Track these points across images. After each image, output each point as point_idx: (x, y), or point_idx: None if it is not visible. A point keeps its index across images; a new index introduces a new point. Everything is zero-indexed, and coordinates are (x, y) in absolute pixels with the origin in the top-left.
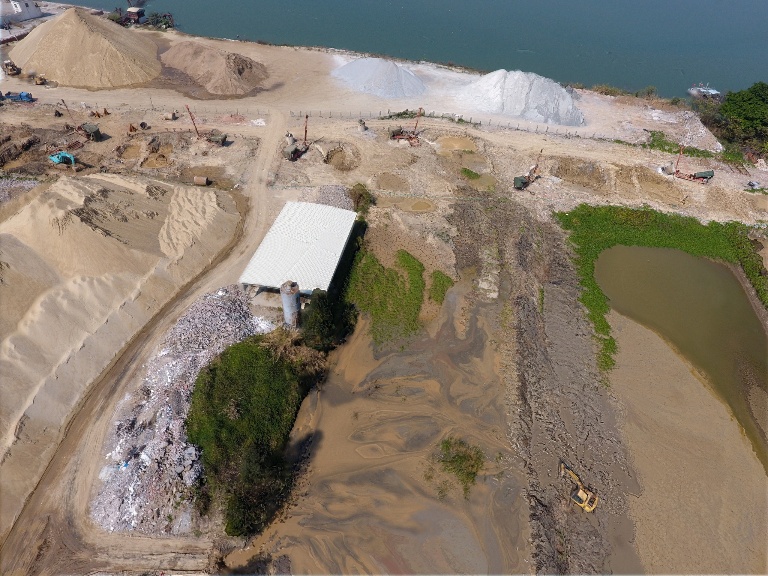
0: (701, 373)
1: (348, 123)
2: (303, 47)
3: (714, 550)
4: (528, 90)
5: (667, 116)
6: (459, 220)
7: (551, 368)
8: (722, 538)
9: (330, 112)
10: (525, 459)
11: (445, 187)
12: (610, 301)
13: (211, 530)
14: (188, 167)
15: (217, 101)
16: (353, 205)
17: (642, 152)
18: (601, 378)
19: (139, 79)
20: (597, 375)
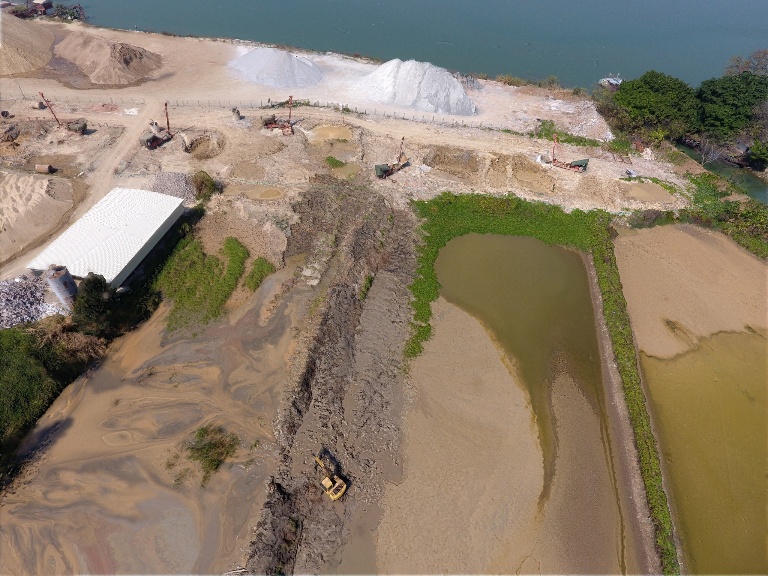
0: (511, 360)
1: (225, 112)
2: (208, 38)
3: (458, 539)
4: (421, 80)
5: (566, 106)
6: (306, 208)
7: (351, 355)
8: (472, 526)
9: (208, 101)
10: (284, 446)
11: (302, 175)
12: (442, 288)
13: None
14: (37, 155)
15: (96, 91)
16: (195, 193)
17: (527, 141)
18: (402, 365)
19: (21, 69)
20: (400, 362)
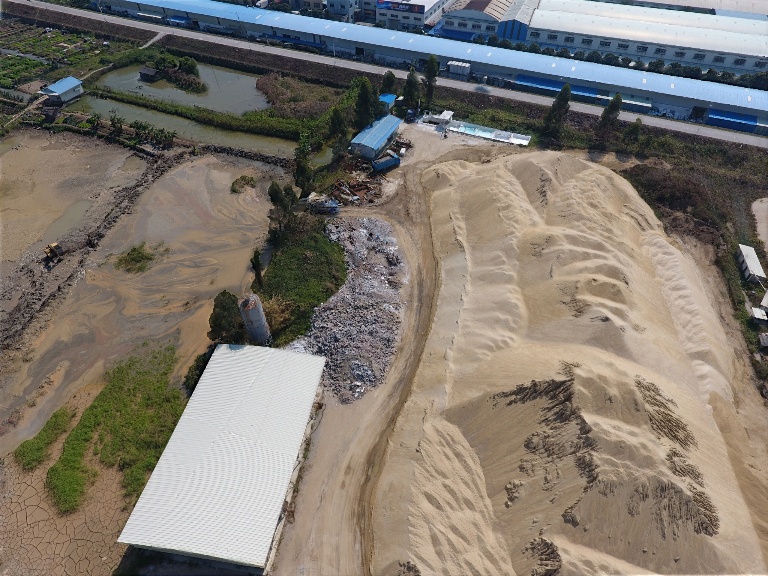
0: None
1: None
2: None
3: None
4: None
5: None
6: None
7: None
8: None
9: None
10: None
11: None
12: None
13: None
14: None
15: None
16: None
17: None
18: None
19: None
20: None
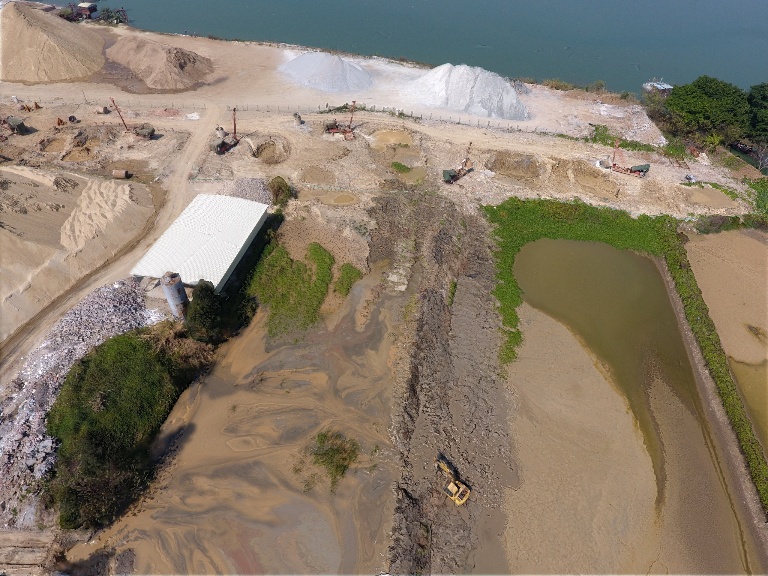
0: (604, 366)
1: (285, 117)
2: (254, 42)
3: (584, 543)
4: (473, 84)
5: (615, 110)
6: (381, 213)
7: (449, 361)
8: (595, 531)
9: (267, 106)
10: (403, 452)
11: (372, 180)
12: (524, 294)
13: (56, 523)
14: (111, 160)
15: (155, 95)
16: (272, 198)
17: (583, 146)
18: (500, 371)
19: (78, 73)
20: (496, 368)
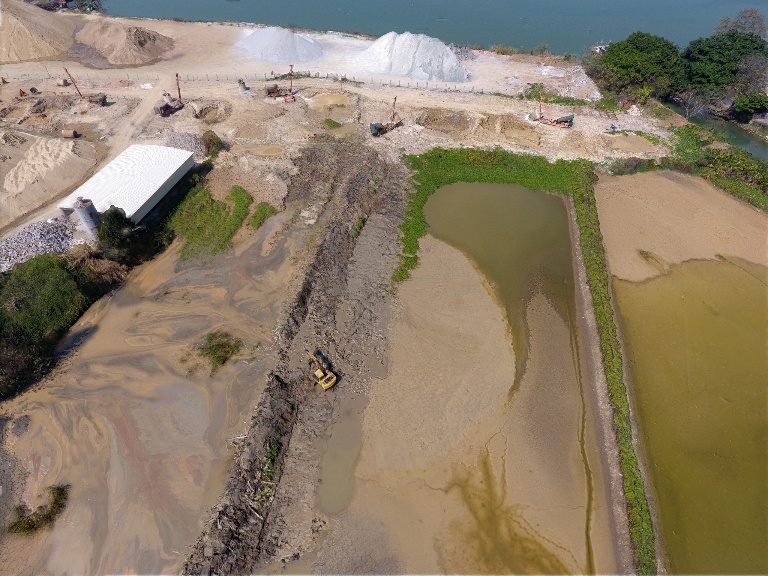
0: (491, 284)
1: (232, 85)
2: (216, 22)
3: (435, 420)
4: (416, 50)
5: (557, 71)
6: (306, 162)
7: (343, 280)
8: (447, 411)
9: (216, 75)
10: (283, 348)
11: (302, 135)
12: (429, 227)
13: None
14: (63, 124)
15: (114, 70)
16: (204, 150)
17: (517, 103)
18: (390, 288)
19: (46, 53)
20: (388, 286)
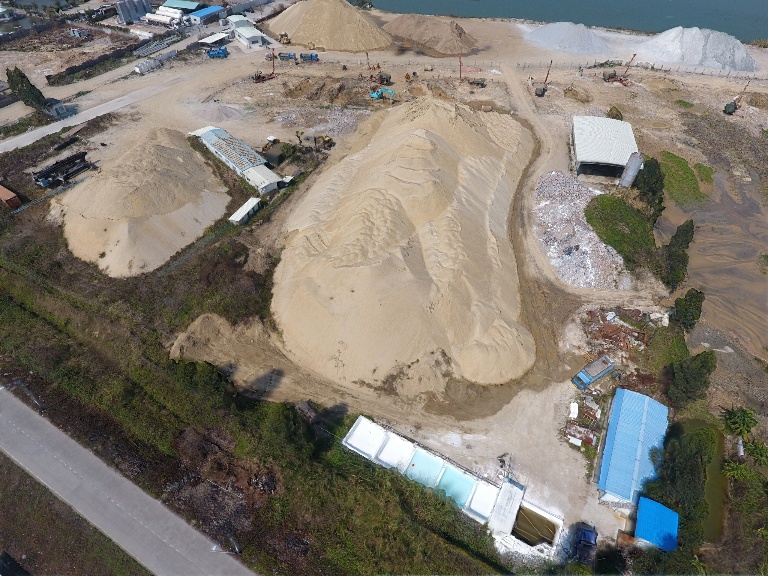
0: None
1: (564, 71)
2: (489, 18)
3: None
4: (704, 43)
5: None
6: (693, 134)
7: None
8: None
9: (548, 63)
10: None
11: (671, 112)
12: None
13: (645, 288)
14: (467, 101)
15: (451, 58)
16: None
17: None
18: None
19: (382, 44)
20: None
